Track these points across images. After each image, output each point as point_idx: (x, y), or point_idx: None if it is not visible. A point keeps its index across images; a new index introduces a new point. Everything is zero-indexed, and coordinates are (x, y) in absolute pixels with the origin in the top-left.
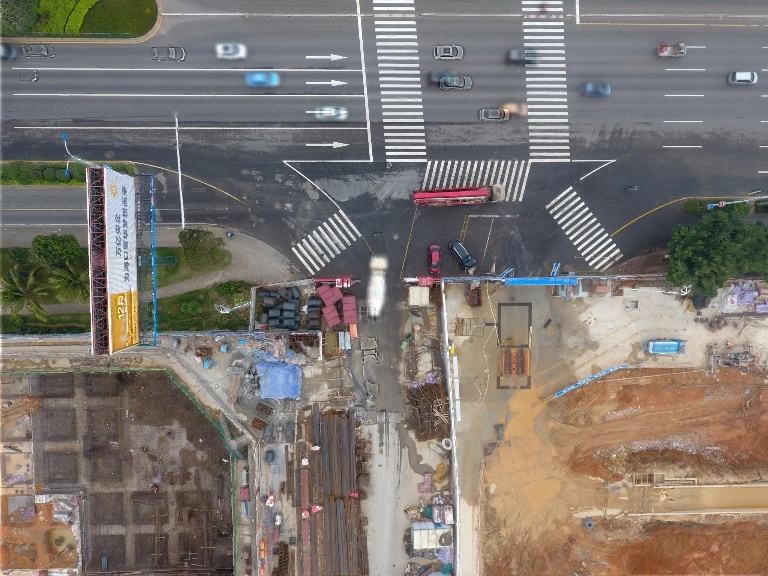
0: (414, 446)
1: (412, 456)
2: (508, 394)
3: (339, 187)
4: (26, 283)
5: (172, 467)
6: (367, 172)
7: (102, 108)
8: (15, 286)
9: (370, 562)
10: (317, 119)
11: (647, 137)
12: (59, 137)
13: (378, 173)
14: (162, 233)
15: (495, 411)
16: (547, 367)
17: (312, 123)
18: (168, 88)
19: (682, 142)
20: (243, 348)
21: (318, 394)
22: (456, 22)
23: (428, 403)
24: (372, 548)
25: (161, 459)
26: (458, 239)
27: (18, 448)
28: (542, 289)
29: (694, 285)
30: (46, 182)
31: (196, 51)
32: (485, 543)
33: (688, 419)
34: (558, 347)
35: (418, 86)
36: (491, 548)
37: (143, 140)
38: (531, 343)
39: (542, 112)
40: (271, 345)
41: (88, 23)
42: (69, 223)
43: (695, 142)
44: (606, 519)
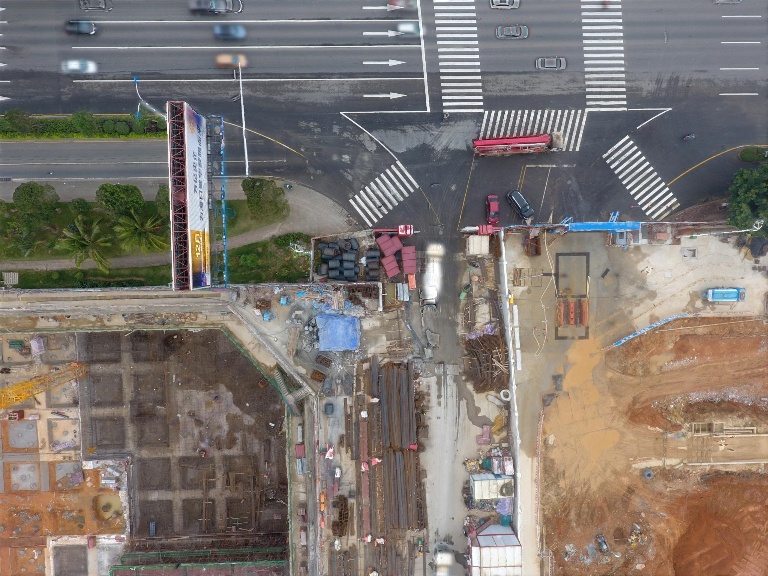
0: (472, 398)
1: (470, 408)
2: (566, 345)
3: (396, 138)
4: (90, 233)
5: (219, 432)
6: (424, 123)
7: (160, 61)
8: None
9: (429, 515)
10: (374, 70)
11: (703, 85)
12: (117, 90)
13: (435, 124)
14: (220, 186)
15: (553, 362)
16: (605, 317)
17: (369, 74)
18: (225, 40)
19: (738, 90)
20: (302, 301)
21: (376, 346)
22: None
23: (487, 354)
24: (431, 501)
25: (208, 424)
26: (516, 188)
27: (65, 414)
28: (599, 239)
29: None
30: (105, 135)
31: (253, 3)
32: (544, 495)
33: (743, 370)
34: (616, 297)
35: (475, 36)
36: (550, 499)
37: (201, 92)
38: (589, 293)
39: (599, 60)
40: (330, 297)
41: None
42: (128, 177)
43: (751, 89)
44: (665, 469)
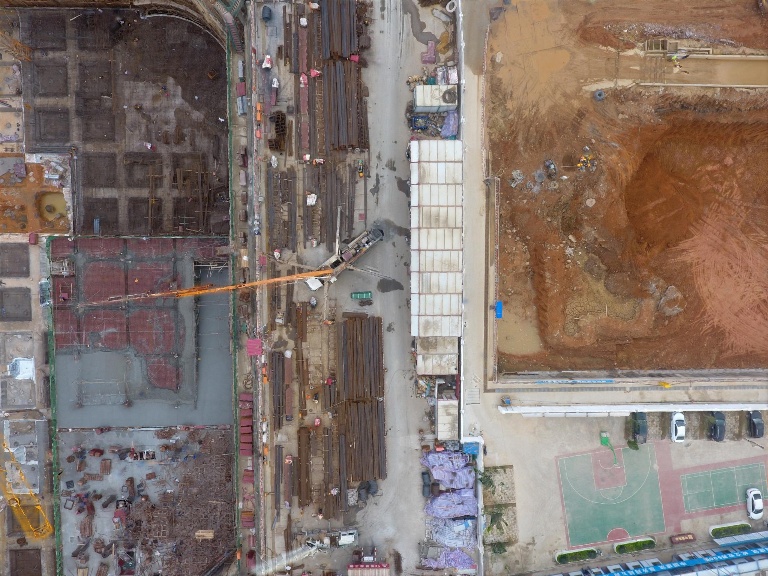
0: (417, 12)
1: (415, 23)
2: None
3: None
4: None
5: (167, 127)
6: None
7: None
8: None
9: (371, 137)
10: None
11: None
12: None
13: None
14: None
15: None
16: None
17: None
18: None
19: None
20: None
21: None
22: None
23: None
24: (373, 122)
25: (155, 118)
26: None
27: (8, 103)
28: None
29: None
30: None
31: None
32: (490, 117)
33: (702, 9)
34: None
35: None
36: (497, 121)
37: None
38: None
39: None
40: None
41: None
42: None
43: None
44: (617, 90)
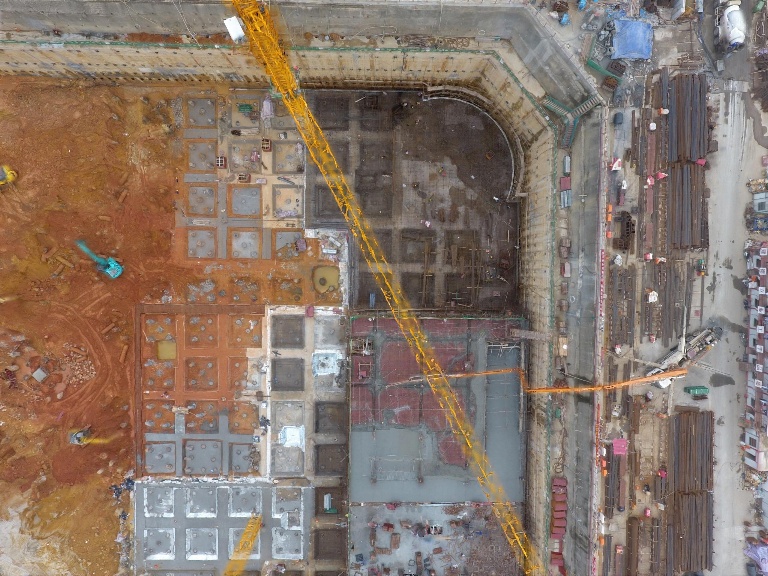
0: (759, 117)
1: (757, 127)
2: None
3: None
4: None
5: (441, 205)
6: None
7: None
8: None
9: (710, 236)
10: None
11: None
12: None
13: None
14: None
15: None
16: None
17: None
18: None
19: None
20: (596, 7)
21: (668, 58)
22: None
23: None
24: (712, 222)
25: (431, 196)
26: None
27: (291, 180)
28: None
29: None
30: None
31: None
32: None
33: None
34: None
35: None
36: None
37: None
38: None
39: None
40: (626, 3)
41: None
42: None
43: None
44: None
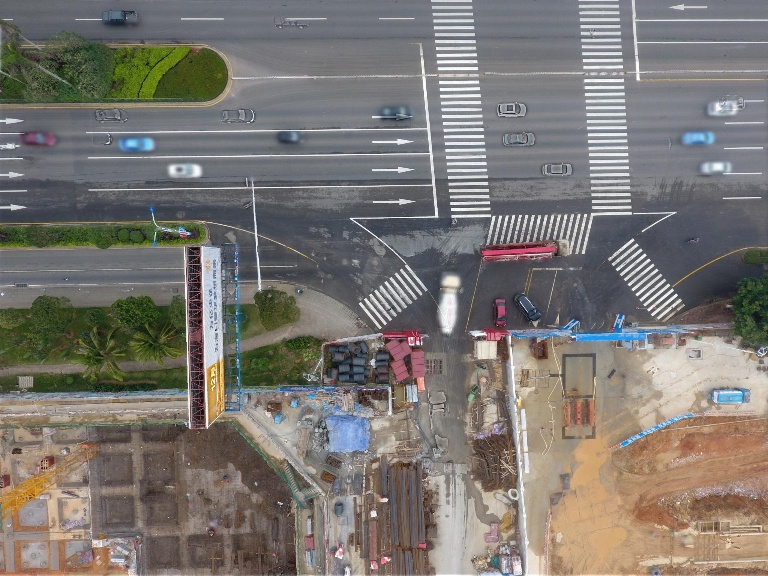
0: (480, 496)
1: (478, 506)
2: (573, 444)
3: (405, 243)
4: (105, 345)
5: (227, 510)
6: (433, 228)
7: (174, 170)
8: (94, 348)
9: None
10: (383, 177)
11: (707, 189)
12: (132, 198)
13: (443, 228)
14: (232, 290)
15: (561, 461)
16: (611, 417)
17: (379, 181)
18: (238, 149)
19: (742, 193)
20: (312, 402)
21: (386, 446)
22: (519, 80)
23: (495, 454)
24: None
25: (217, 502)
26: (523, 293)
27: (76, 493)
28: None
29: (762, 339)
30: (120, 243)
31: (265, 113)
32: None
33: (749, 464)
34: (622, 397)
35: (482, 143)
36: None
37: (214, 200)
38: (595, 393)
39: (604, 167)
40: (340, 399)
41: (162, 88)
42: (141, 282)
43: (754, 193)
44: (672, 567)
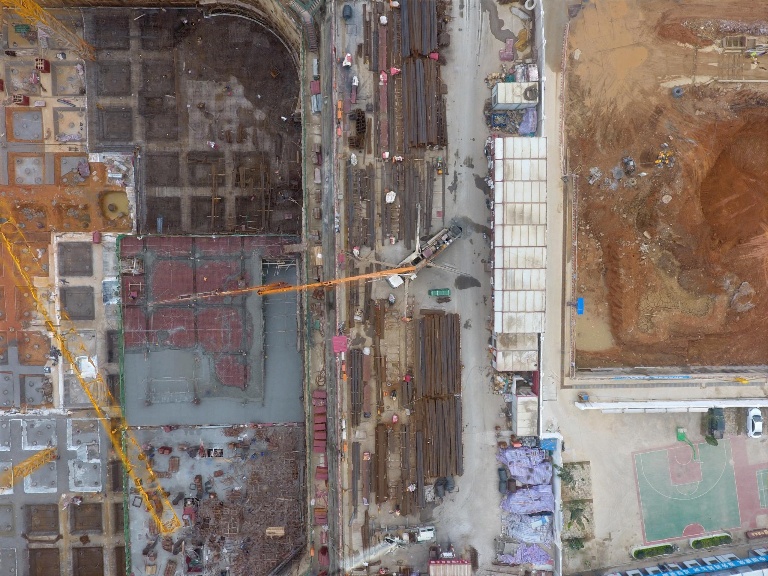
0: (495, 10)
1: (493, 21)
2: None
3: None
4: None
5: (229, 126)
6: None
7: None
8: None
9: (449, 134)
10: None
11: None
12: None
13: None
14: None
15: None
16: None
17: None
18: None
19: None
20: None
21: None
22: None
23: None
24: (451, 119)
25: (218, 117)
26: None
27: (72, 103)
28: None
29: None
30: None
31: None
32: (568, 114)
33: None
34: None
35: None
36: (575, 118)
37: None
38: None
39: None
40: None
41: None
42: None
43: None
44: (695, 86)
